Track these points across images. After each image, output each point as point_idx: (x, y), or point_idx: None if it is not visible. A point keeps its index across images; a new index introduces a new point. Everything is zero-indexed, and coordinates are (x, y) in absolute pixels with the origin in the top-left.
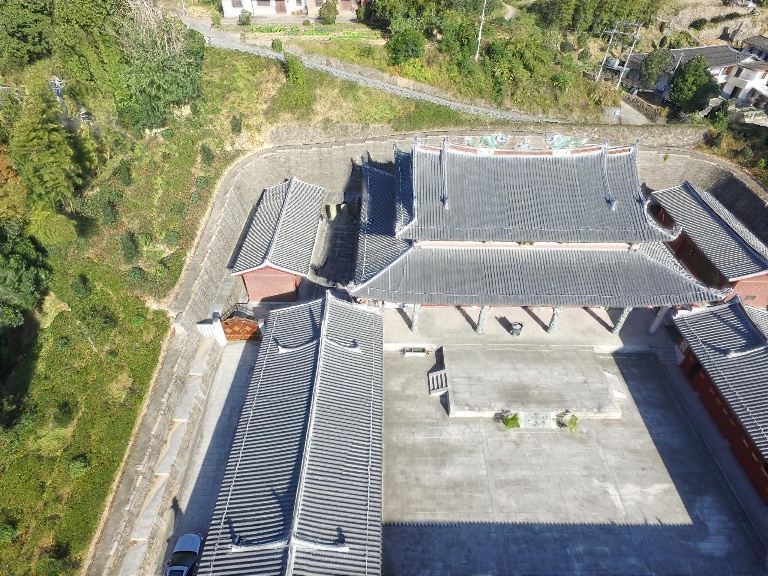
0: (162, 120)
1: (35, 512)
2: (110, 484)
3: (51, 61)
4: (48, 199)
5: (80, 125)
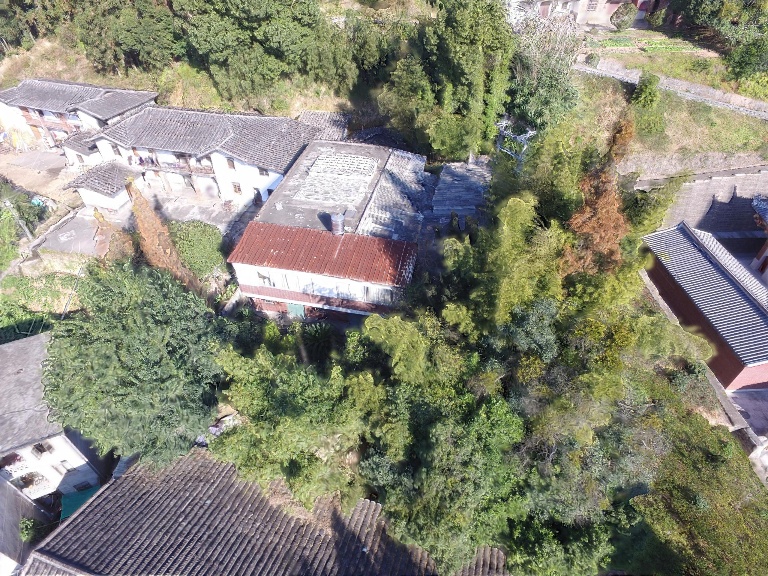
0: None
1: None
2: None
3: (292, 82)
4: None
5: None
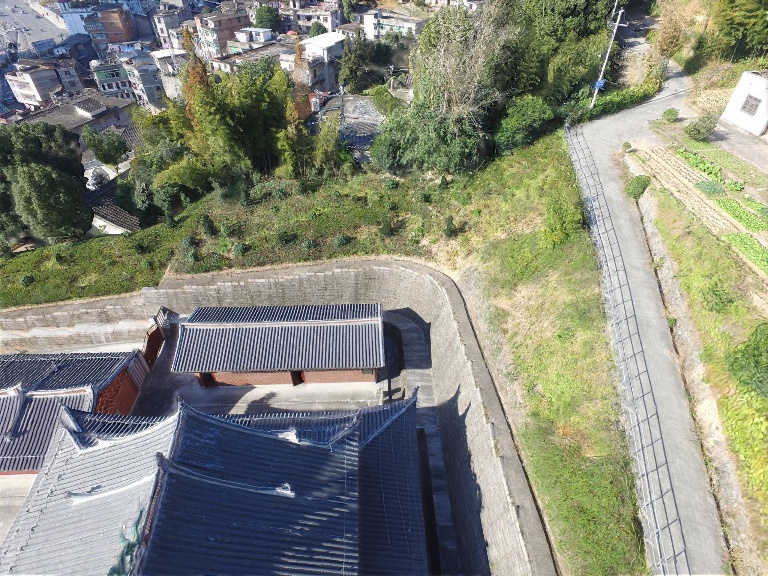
0: (407, 171)
1: (2, 275)
2: (21, 305)
3: None
4: (223, 159)
5: (288, 126)
